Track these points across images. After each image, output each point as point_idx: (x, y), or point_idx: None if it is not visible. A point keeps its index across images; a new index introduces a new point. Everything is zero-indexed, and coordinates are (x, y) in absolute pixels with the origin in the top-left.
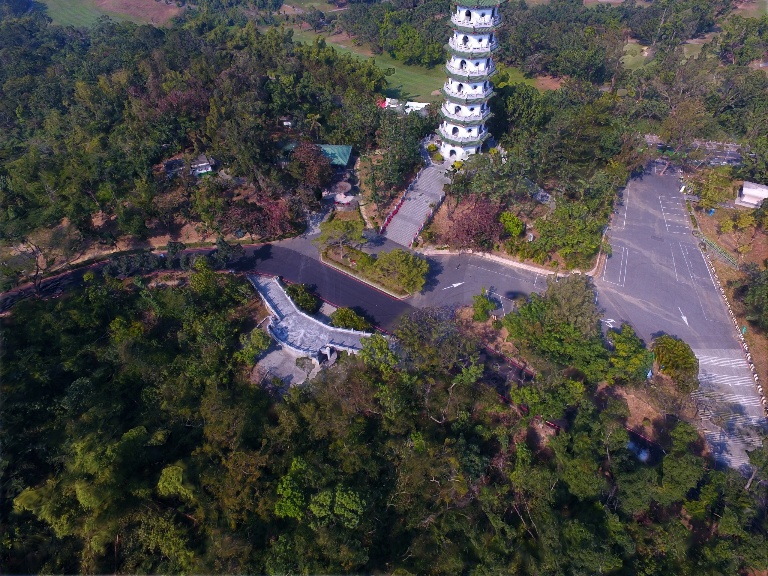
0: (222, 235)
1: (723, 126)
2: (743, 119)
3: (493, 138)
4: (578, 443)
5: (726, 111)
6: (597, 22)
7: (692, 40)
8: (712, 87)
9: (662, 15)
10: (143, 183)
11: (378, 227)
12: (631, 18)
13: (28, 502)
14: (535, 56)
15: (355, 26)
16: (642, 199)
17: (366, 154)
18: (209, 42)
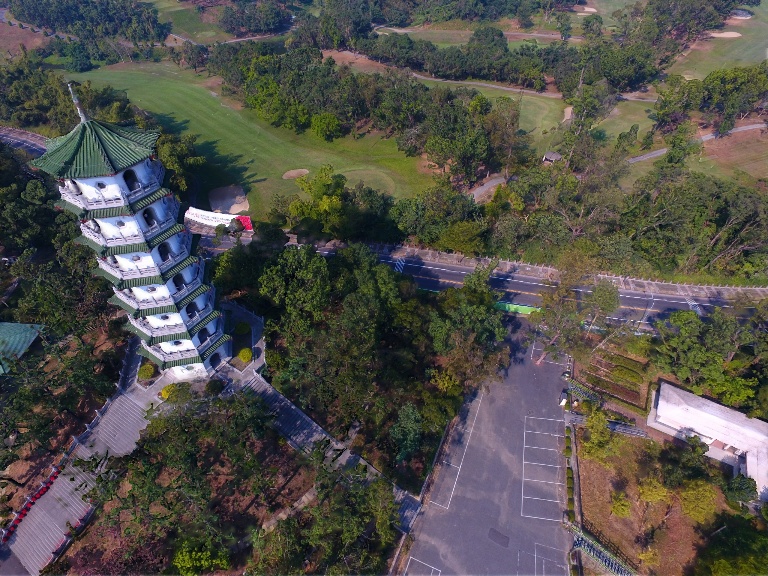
0: None
1: (647, 253)
2: (673, 246)
3: (263, 319)
4: None
5: (650, 232)
6: (514, 71)
7: (631, 94)
8: (629, 200)
9: (579, 76)
10: None
11: (4, 524)
12: (557, 66)
13: None
14: (414, 130)
15: (220, 72)
16: (496, 425)
17: (84, 328)
18: (12, 98)
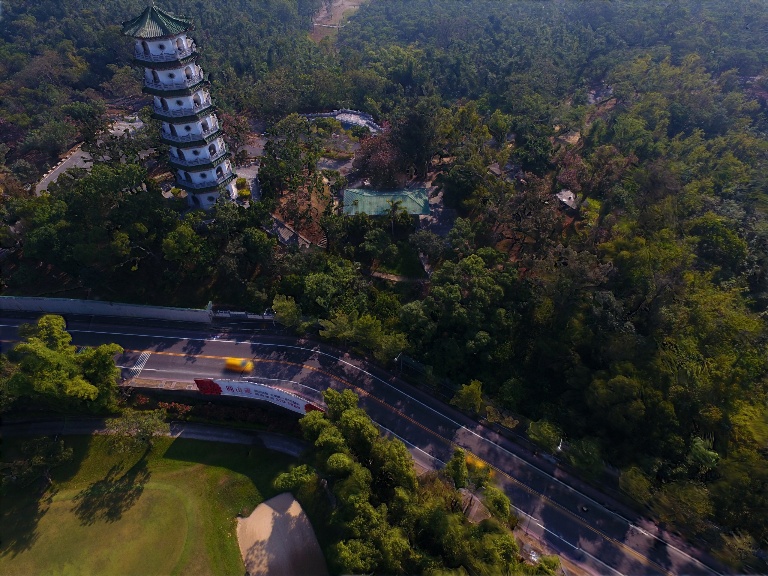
0: (439, 157)
1: None
2: None
3: None
4: (227, 68)
5: None
6: None
7: None
8: None
9: None
10: (497, 113)
11: None
12: None
13: None
14: None
15: None
16: None
17: None
18: None
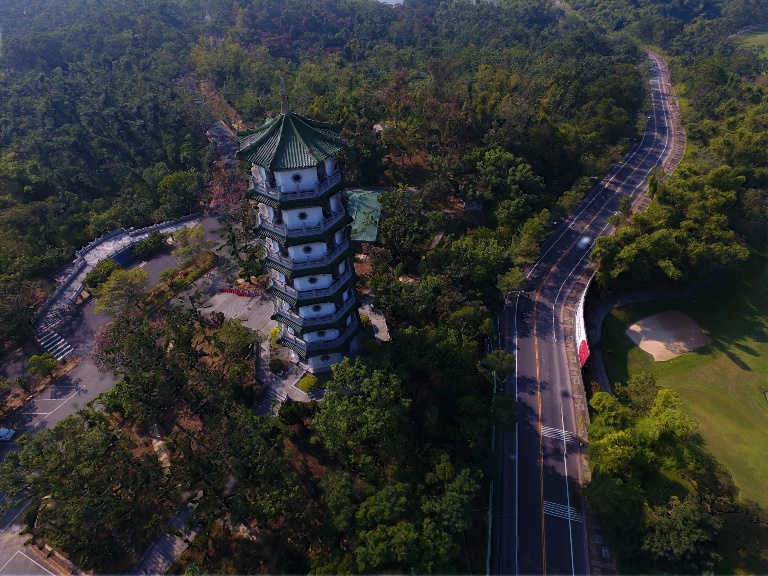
0: None
1: None
2: None
3: None
4: None
5: None
6: None
7: None
8: None
9: None
10: None
11: None
12: None
13: (8, 155)
14: None
15: None
16: None
17: None
18: (718, 112)
